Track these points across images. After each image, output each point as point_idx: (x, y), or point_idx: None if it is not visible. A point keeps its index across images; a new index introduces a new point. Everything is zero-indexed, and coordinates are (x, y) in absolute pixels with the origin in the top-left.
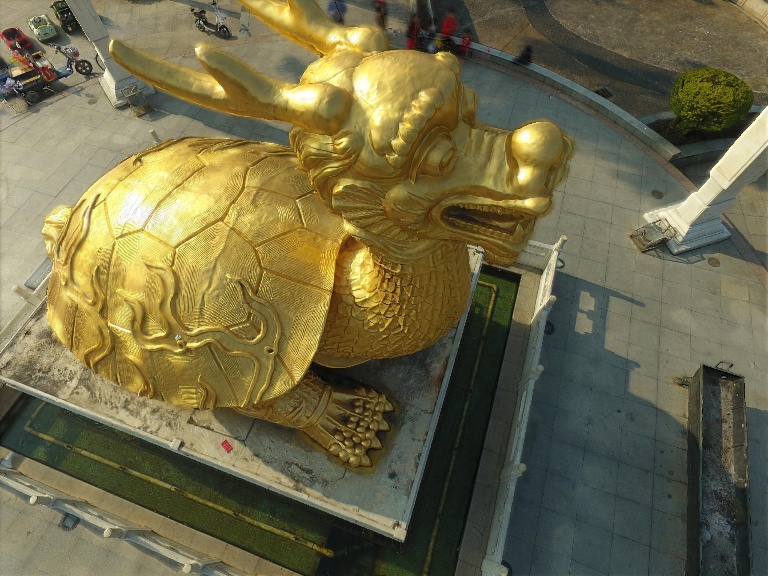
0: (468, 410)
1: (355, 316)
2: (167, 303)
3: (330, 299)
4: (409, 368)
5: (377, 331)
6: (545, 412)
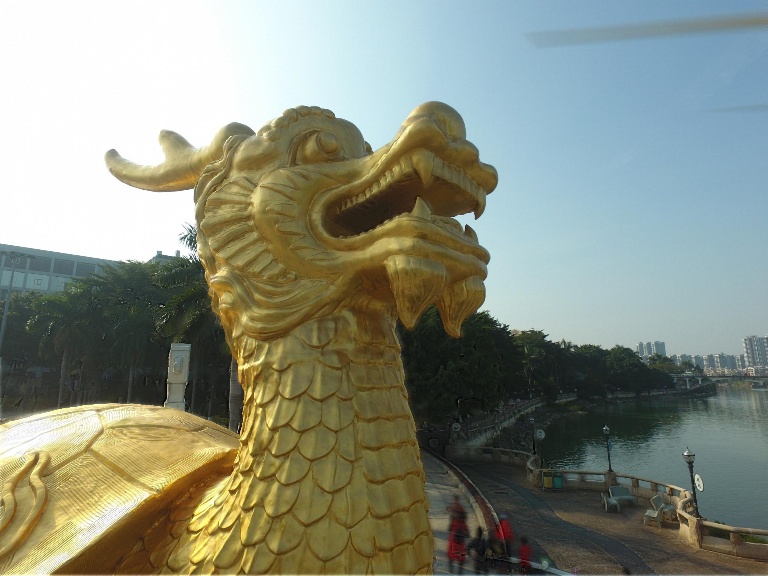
0: None
1: (172, 559)
2: None
3: (147, 500)
4: None
5: None
6: None
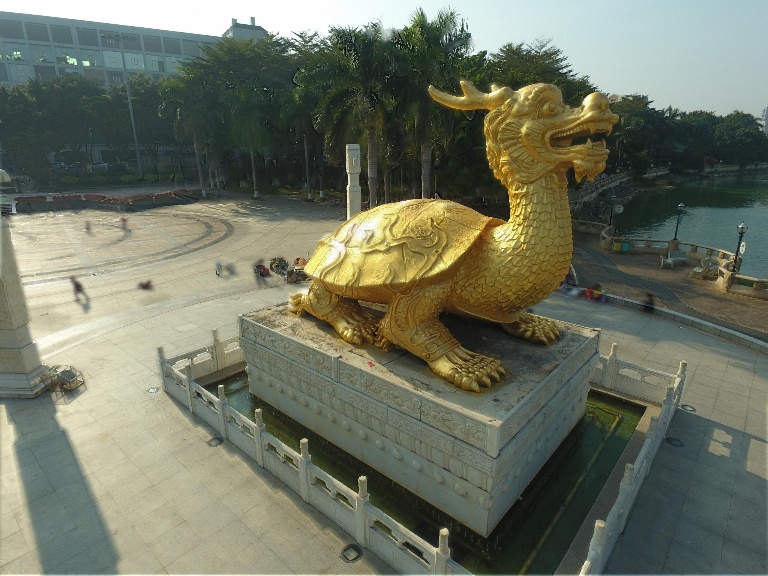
0: (581, 485)
1: (493, 248)
2: (388, 226)
3: (480, 232)
4: (524, 363)
5: (505, 255)
6: (671, 496)
